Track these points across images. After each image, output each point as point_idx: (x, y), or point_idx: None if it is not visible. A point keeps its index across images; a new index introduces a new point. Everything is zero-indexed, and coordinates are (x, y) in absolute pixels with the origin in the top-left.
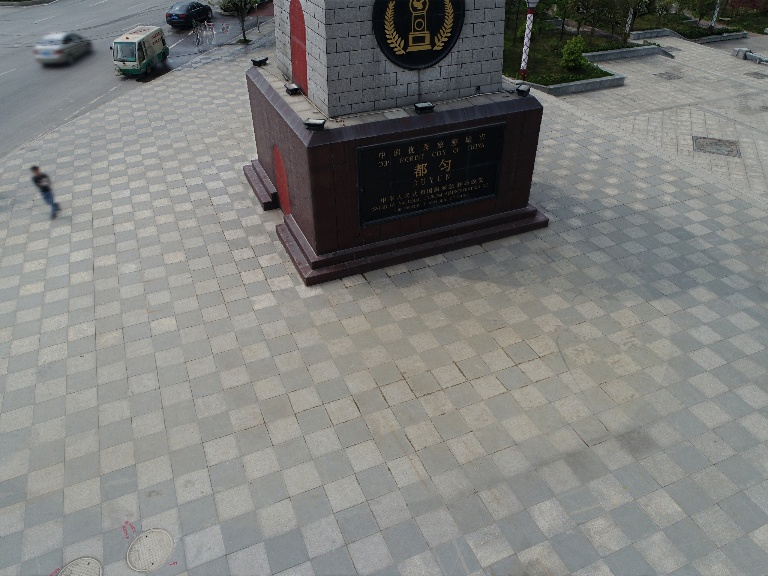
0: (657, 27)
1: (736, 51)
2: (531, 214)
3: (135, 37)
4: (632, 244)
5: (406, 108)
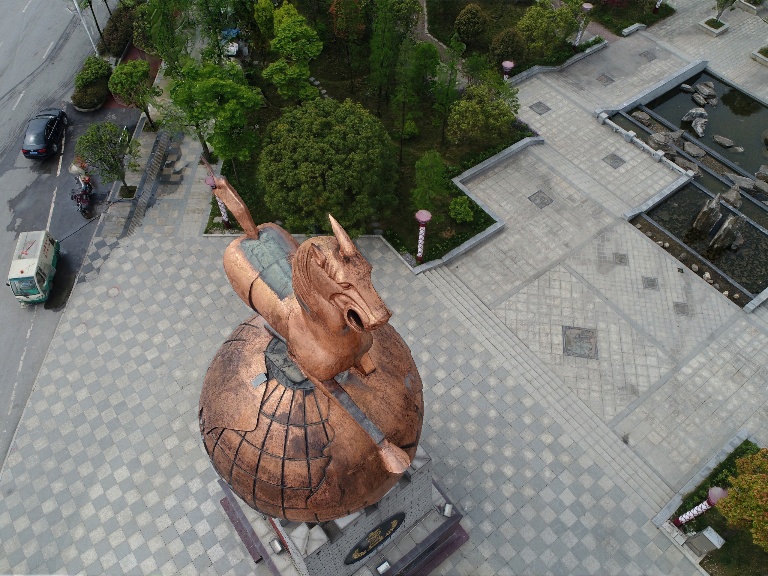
0: (526, 65)
1: (596, 114)
2: (457, 538)
3: (29, 266)
4: (527, 551)
5: (370, 567)
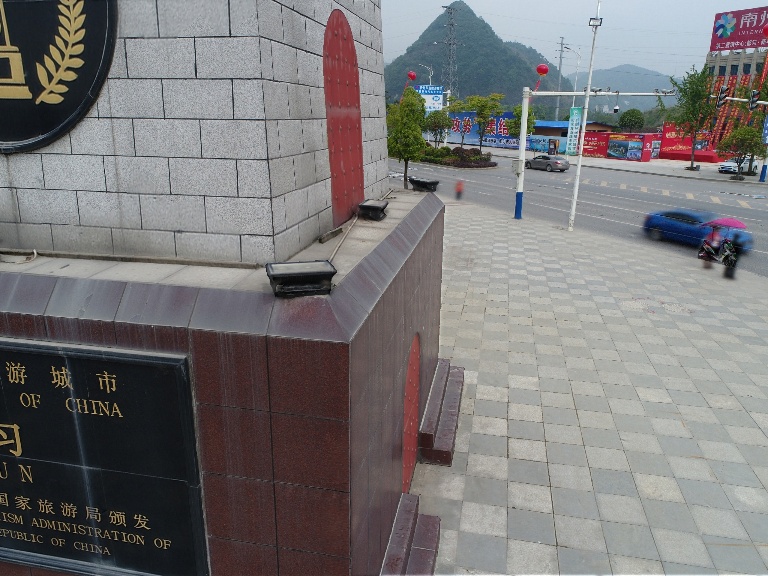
0: None
1: None
2: None
3: None
4: None
5: None
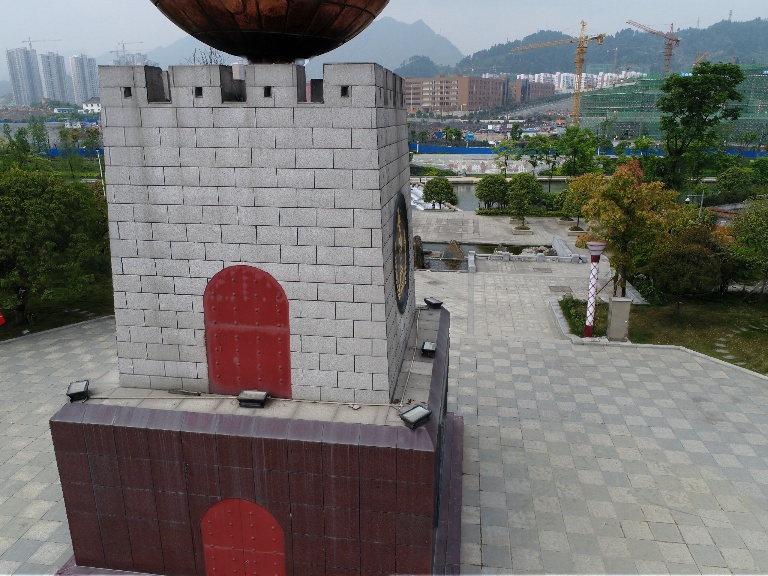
0: None
1: None
2: None
3: None
4: (522, 402)
5: (413, 358)
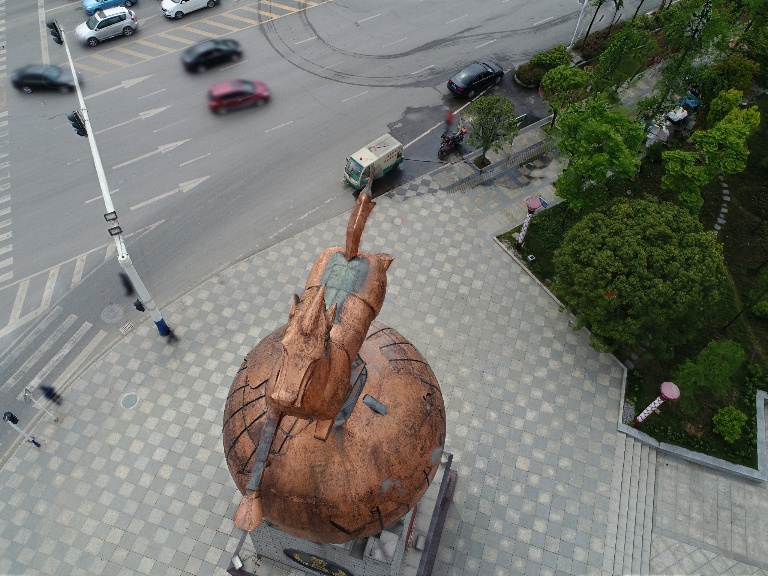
0: None
1: None
2: None
3: (368, 158)
4: None
5: None
